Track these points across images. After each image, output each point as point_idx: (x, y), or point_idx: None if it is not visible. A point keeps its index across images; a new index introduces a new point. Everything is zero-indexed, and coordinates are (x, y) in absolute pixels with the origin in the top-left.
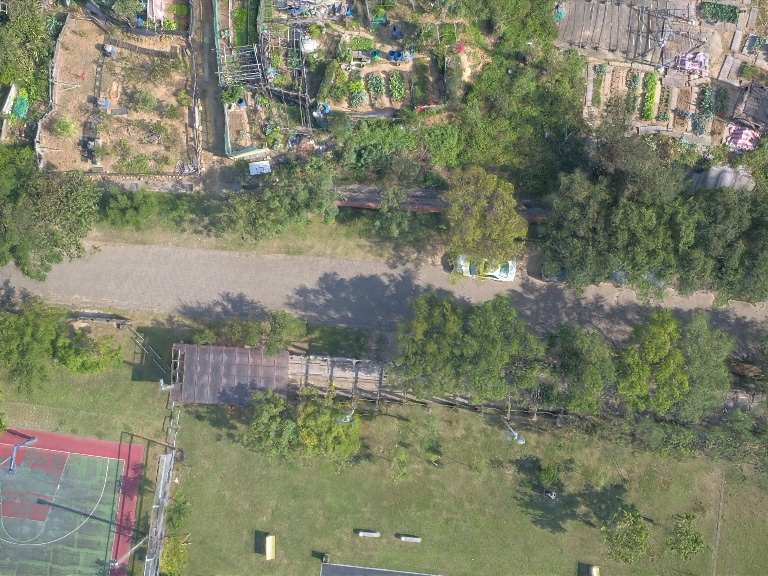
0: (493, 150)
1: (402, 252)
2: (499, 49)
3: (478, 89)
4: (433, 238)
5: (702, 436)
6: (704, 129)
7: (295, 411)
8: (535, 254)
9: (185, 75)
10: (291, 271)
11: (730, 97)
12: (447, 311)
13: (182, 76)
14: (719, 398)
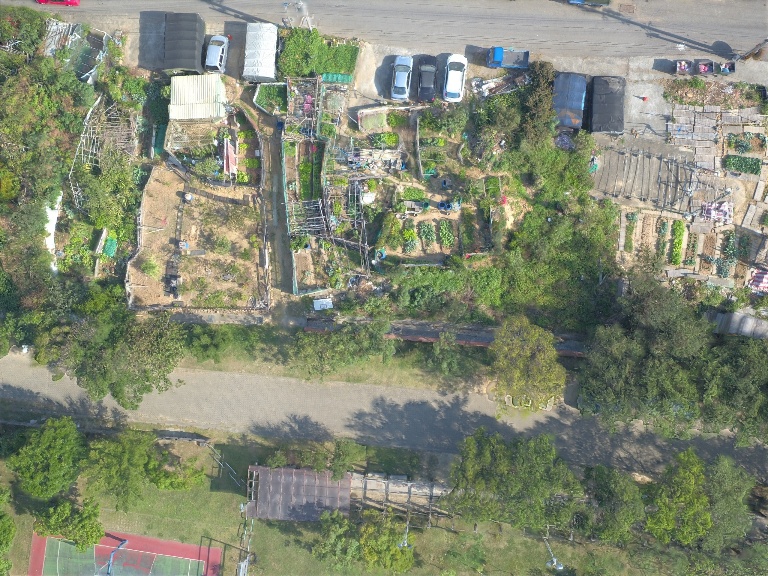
0: (534, 292)
1: (451, 381)
2: (540, 199)
3: (520, 237)
4: (479, 369)
5: (722, 565)
6: (728, 273)
7: (357, 530)
8: (571, 385)
9: (256, 220)
10: (351, 397)
11: (752, 243)
12: (493, 448)
13: (253, 221)
14: (738, 532)
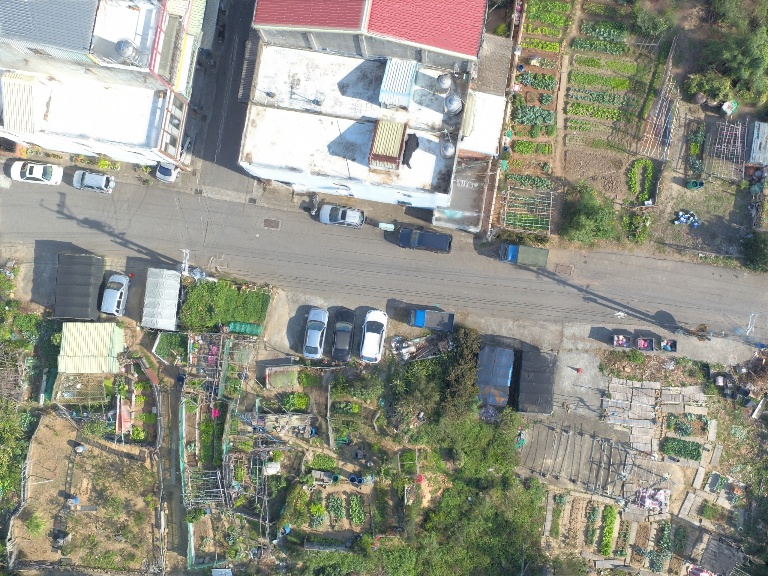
0: None
1: None
2: (460, 475)
3: (437, 520)
4: None
5: None
6: (661, 568)
7: None
8: None
9: None
10: None
11: (689, 536)
12: None
13: (150, 478)
14: None
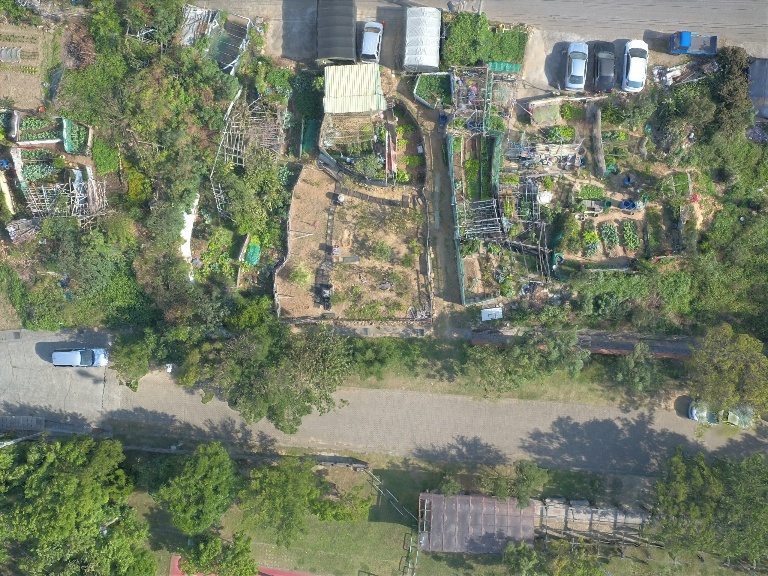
0: (727, 297)
1: (634, 396)
2: (731, 196)
3: (713, 238)
4: (665, 382)
5: None
6: None
7: (547, 563)
8: None
9: None
10: (524, 415)
11: None
12: (703, 470)
13: (413, 224)
14: None
